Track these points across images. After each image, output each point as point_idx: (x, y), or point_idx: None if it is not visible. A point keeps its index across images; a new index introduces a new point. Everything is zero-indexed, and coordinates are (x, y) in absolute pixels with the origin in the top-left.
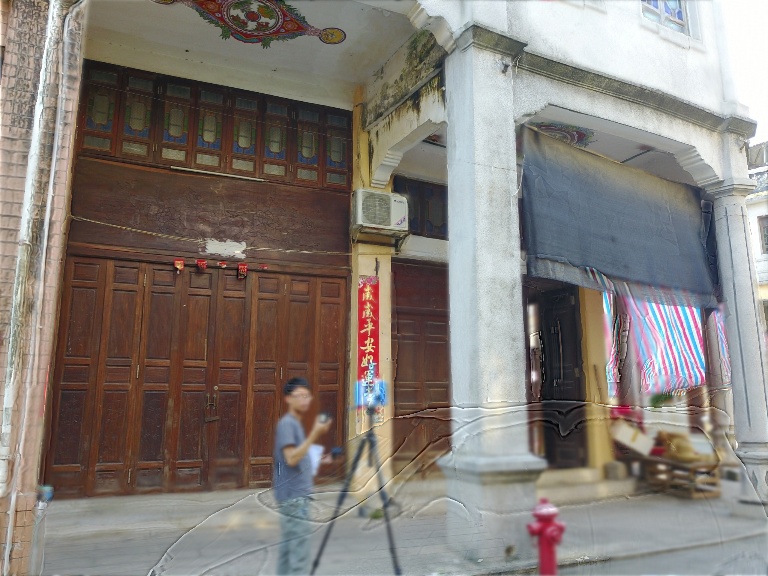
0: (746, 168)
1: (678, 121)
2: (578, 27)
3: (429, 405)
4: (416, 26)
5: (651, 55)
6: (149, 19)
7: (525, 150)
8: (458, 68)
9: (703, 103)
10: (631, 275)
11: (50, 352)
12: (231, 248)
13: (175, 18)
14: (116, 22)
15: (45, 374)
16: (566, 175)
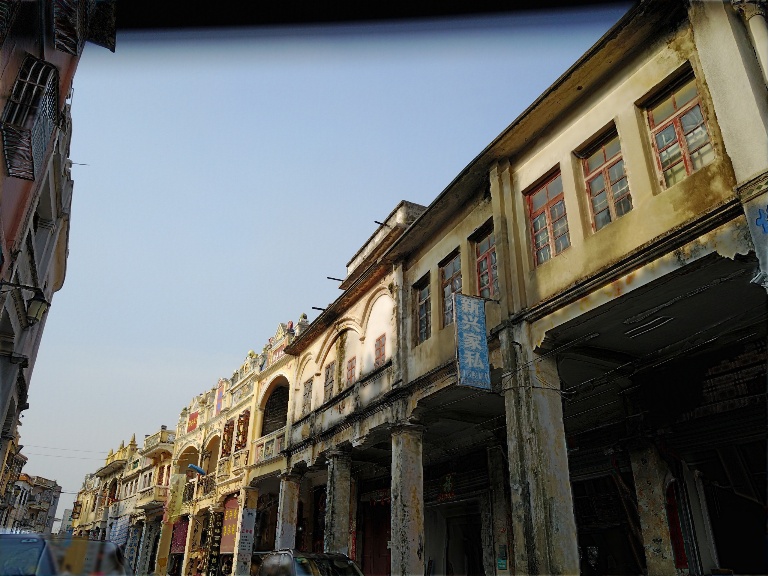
0: None
1: None
2: None
3: None
4: (0, 339)
5: None
6: None
7: None
8: (5, 368)
9: None
10: None
11: None
12: None
13: None
14: None
15: None
16: None
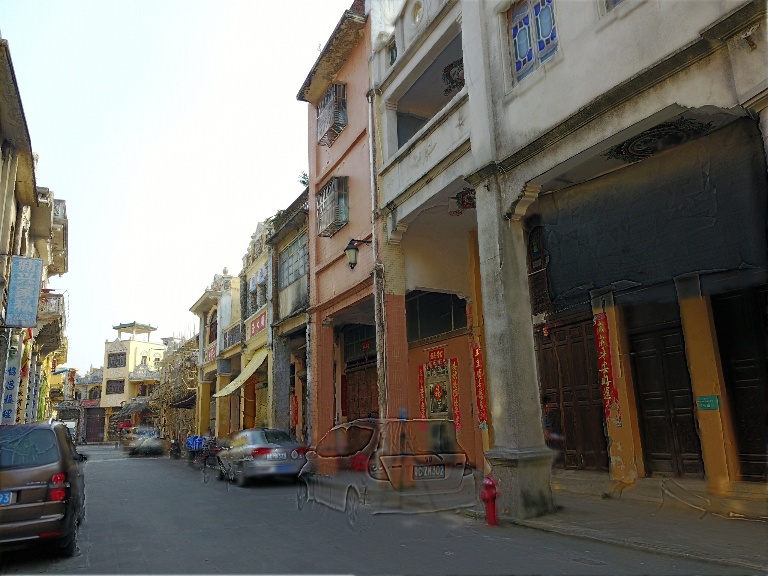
0: (767, 63)
1: (648, 93)
2: (543, 97)
3: (674, 411)
4: None
5: (611, 50)
6: (472, 218)
7: (542, 216)
8: None
9: (688, 35)
10: (658, 273)
11: (398, 402)
12: (539, 318)
13: (474, 213)
14: (471, 224)
15: (392, 411)
16: (576, 214)
